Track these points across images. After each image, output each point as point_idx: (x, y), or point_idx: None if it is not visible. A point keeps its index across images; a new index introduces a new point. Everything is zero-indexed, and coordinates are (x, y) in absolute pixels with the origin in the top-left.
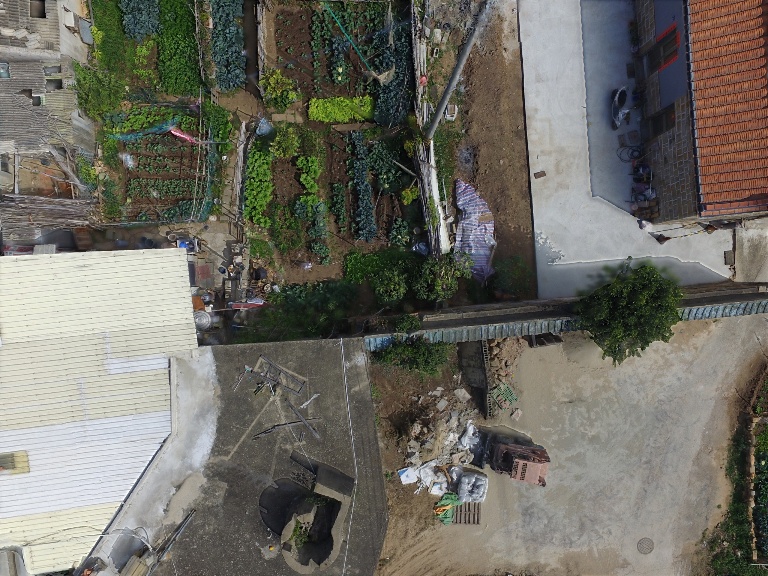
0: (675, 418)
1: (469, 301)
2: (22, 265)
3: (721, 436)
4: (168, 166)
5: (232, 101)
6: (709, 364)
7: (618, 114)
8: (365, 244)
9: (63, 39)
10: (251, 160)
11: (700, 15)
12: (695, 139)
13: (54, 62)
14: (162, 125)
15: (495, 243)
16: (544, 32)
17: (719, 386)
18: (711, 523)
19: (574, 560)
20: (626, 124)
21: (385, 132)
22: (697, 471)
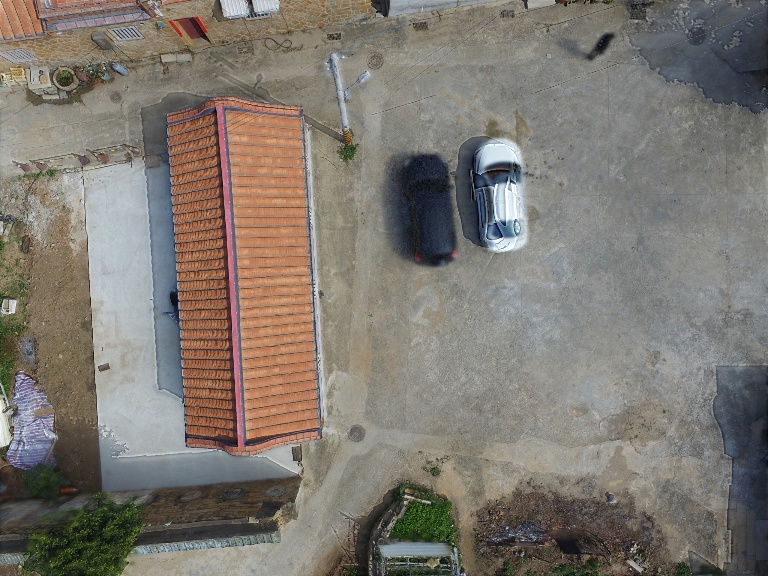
0: None
1: None
2: None
3: None
4: None
5: None
6: (285, 556)
7: None
8: None
9: None
10: None
11: (182, 246)
12: (182, 369)
13: None
14: None
15: (54, 437)
16: (110, 224)
17: None
18: None
19: None
20: None
21: None
22: None
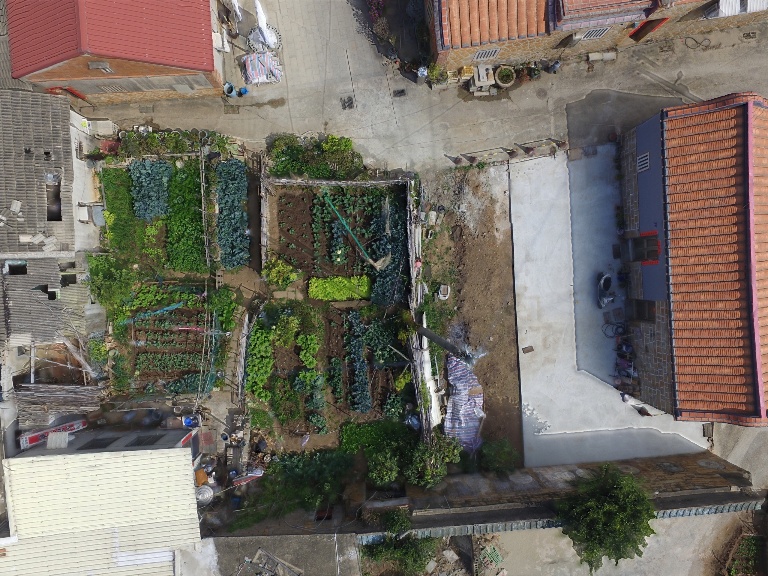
0: None
1: (458, 469)
2: (38, 466)
3: None
4: (175, 341)
5: (236, 277)
6: (687, 527)
7: (603, 298)
8: (360, 414)
9: (77, 235)
10: (253, 338)
11: (679, 233)
12: (673, 348)
13: (69, 258)
14: (169, 302)
15: (484, 415)
16: (534, 214)
17: (696, 548)
18: None
19: None
20: (611, 302)
21: (381, 309)
22: None
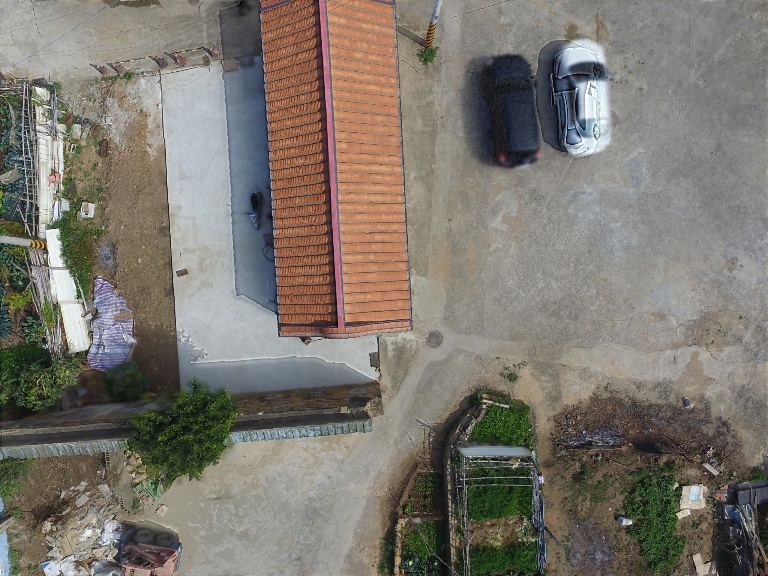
0: (325, 516)
1: (109, 398)
2: None
3: (373, 534)
4: None
5: None
6: (360, 463)
7: None
8: (3, 339)
9: None
10: None
11: (276, 134)
12: (274, 258)
13: None
14: None
15: (134, 341)
16: (188, 128)
17: (371, 485)
18: None
19: None
20: None
21: None
22: (348, 568)
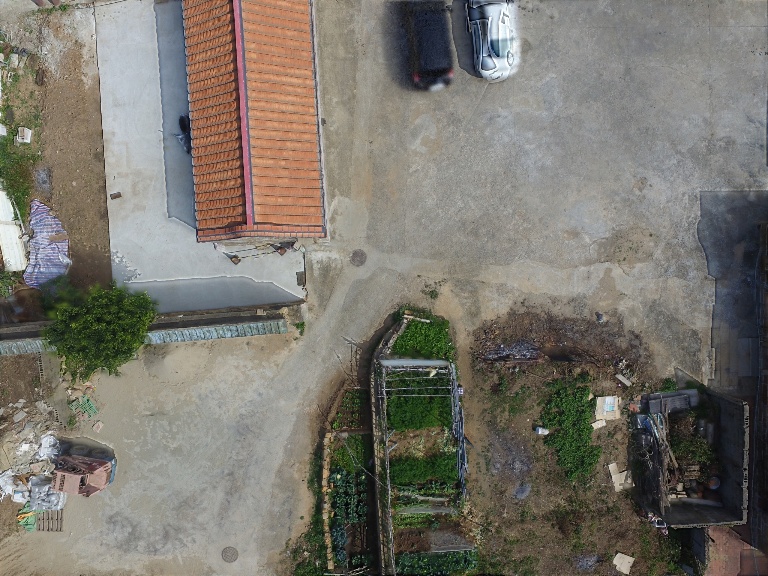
0: (257, 432)
1: (45, 317)
2: None
3: (303, 450)
4: None
5: None
6: (290, 380)
7: None
8: None
9: None
10: None
11: (192, 48)
12: None
13: None
14: None
15: (69, 261)
16: (121, 58)
17: (300, 402)
18: (294, 533)
19: (159, 567)
20: None
21: None
22: (280, 483)
